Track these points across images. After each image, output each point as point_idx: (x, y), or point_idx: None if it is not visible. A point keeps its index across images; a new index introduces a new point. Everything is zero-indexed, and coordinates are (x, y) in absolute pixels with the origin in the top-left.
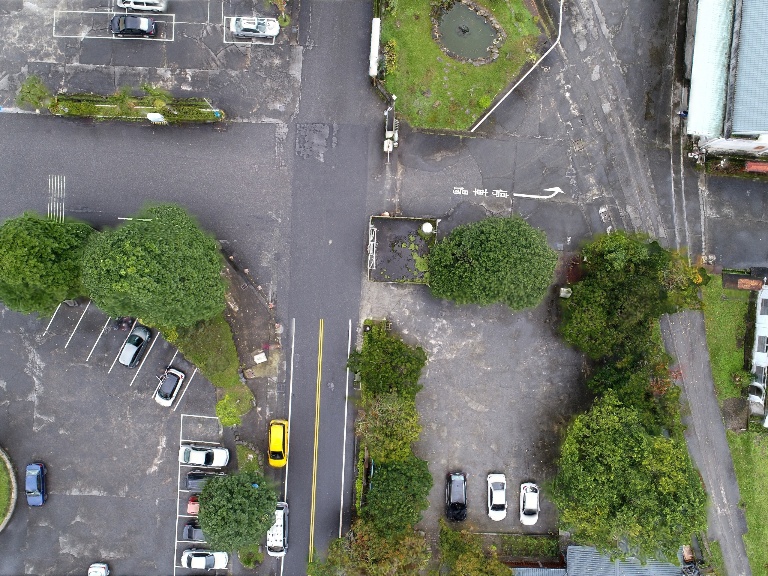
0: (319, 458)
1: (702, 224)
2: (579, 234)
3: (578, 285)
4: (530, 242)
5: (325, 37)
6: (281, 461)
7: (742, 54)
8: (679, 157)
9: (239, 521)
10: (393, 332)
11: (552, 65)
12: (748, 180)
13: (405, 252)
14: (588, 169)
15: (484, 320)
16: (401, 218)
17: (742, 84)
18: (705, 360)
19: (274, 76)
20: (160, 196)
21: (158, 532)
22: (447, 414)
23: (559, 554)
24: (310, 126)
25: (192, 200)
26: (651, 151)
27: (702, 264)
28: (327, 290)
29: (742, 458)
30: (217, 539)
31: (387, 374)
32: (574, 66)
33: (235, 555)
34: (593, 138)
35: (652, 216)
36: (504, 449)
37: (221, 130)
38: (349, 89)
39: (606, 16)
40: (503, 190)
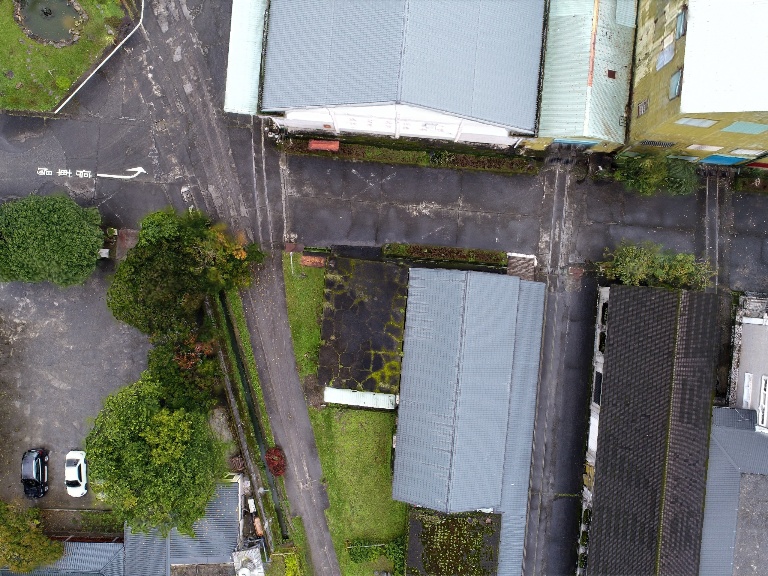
0: None
1: (283, 203)
2: None
3: None
4: (64, 219)
5: None
6: None
7: (270, 32)
8: (260, 137)
9: None
10: None
11: (135, 47)
12: (328, 159)
13: None
14: (170, 149)
15: (67, 299)
16: None
17: (269, 62)
18: (287, 337)
19: None
20: None
21: None
22: (30, 392)
23: None
24: None
25: None
26: (232, 131)
27: (284, 242)
28: None
29: (323, 434)
30: None
31: None
32: (156, 47)
33: None
34: (175, 118)
35: (233, 195)
36: (86, 426)
37: None
38: None
39: None
40: (86, 170)
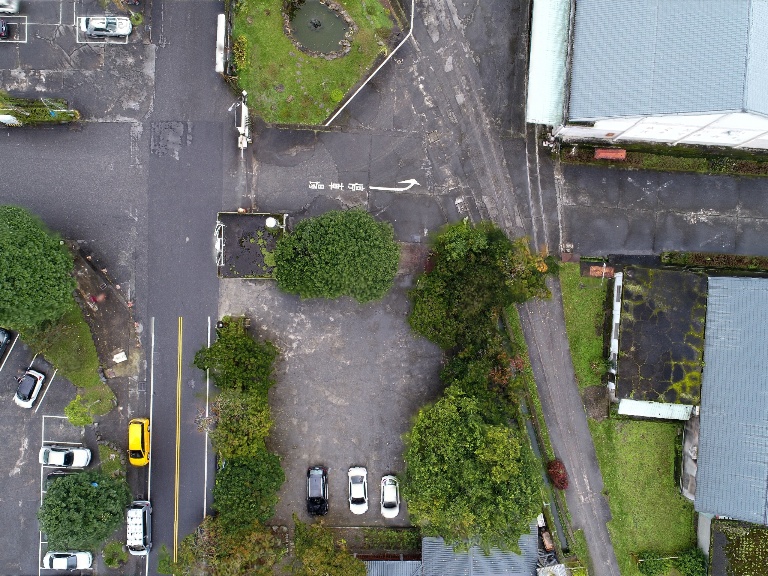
0: (181, 456)
1: (559, 212)
2: (436, 225)
3: (422, 276)
4: (370, 234)
5: (177, 35)
6: (142, 460)
7: (577, 41)
8: (534, 146)
9: (73, 520)
10: (252, 328)
11: (405, 57)
12: (604, 167)
13: (254, 247)
14: (443, 160)
15: (342, 314)
16: (248, 214)
17: (577, 71)
18: (565, 348)
19: (128, 75)
20: (16, 198)
21: (22, 534)
22: (307, 409)
23: (420, 546)
24: (165, 124)
25: (48, 201)
26: (506, 141)
27: (560, 253)
28: (185, 288)
29: (604, 446)
30: (53, 539)
31: (230, 370)
32: (427, 58)
33: (100, 555)
34: (448, 129)
35: (508, 206)
36: (365, 442)
37: (76, 130)
38: (203, 86)
39: (457, 7)
40: (359, 183)
